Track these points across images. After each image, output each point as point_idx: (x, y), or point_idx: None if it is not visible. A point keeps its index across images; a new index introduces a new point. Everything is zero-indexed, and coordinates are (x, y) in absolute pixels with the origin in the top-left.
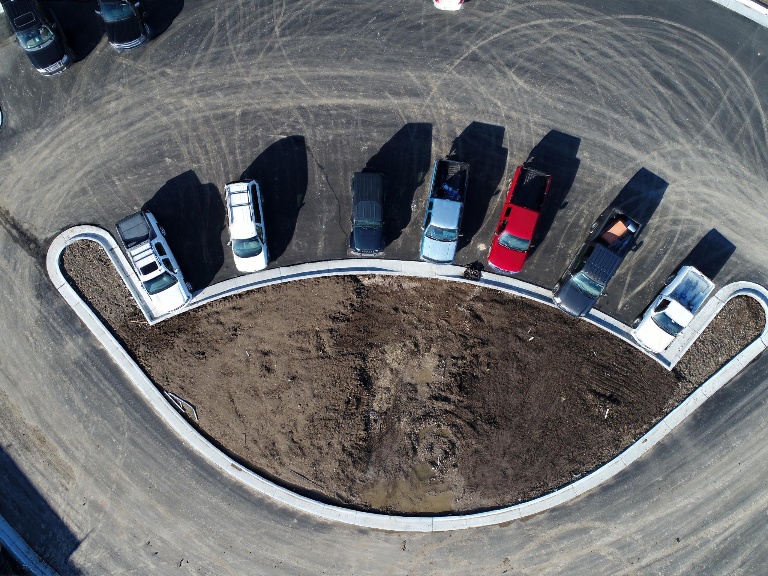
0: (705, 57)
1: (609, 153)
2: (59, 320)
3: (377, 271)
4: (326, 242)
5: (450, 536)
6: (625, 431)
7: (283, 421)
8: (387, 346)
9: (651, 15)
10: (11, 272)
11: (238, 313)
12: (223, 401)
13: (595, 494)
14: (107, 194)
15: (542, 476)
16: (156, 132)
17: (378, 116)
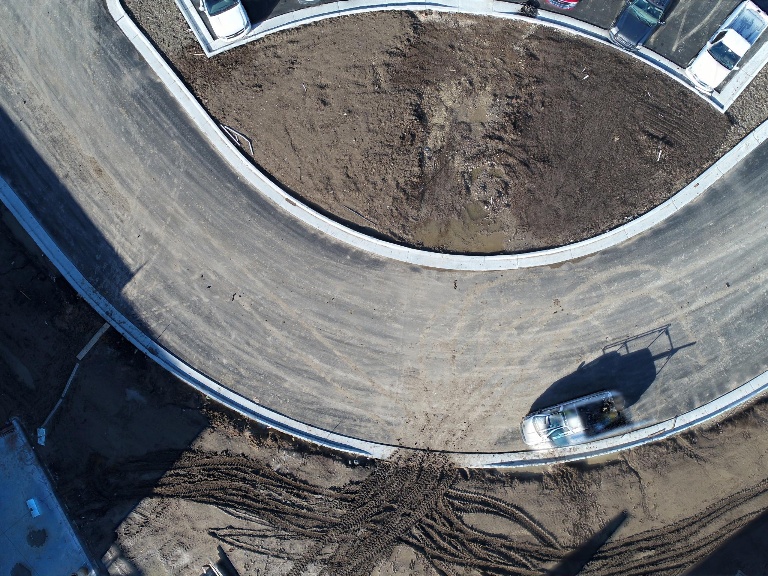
0: None
1: None
2: (117, 53)
3: (434, 6)
4: None
5: (501, 276)
6: (677, 174)
7: (338, 155)
8: (442, 83)
9: None
10: (70, 4)
11: (295, 46)
12: (279, 134)
13: (646, 237)
14: None
15: (594, 217)
16: None
17: None
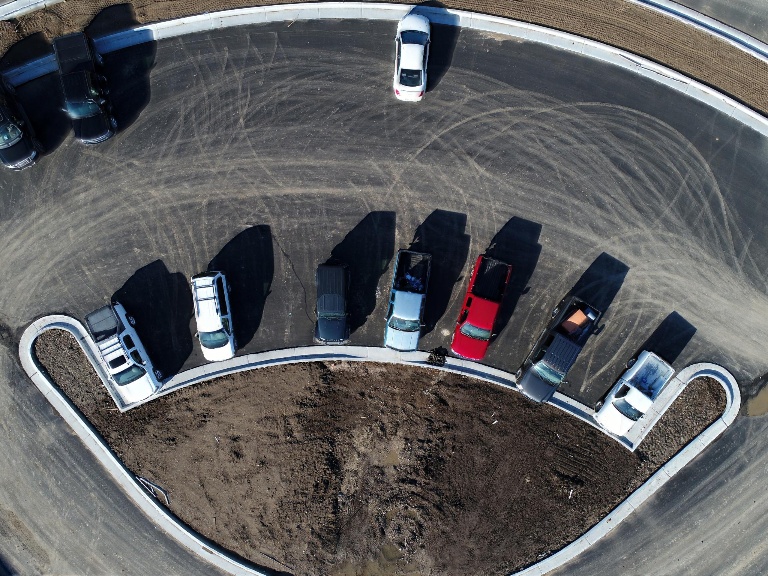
0: (664, 143)
1: (570, 238)
2: (32, 408)
3: (343, 358)
4: (292, 329)
5: None
6: (589, 511)
7: (252, 505)
8: (354, 430)
9: (610, 102)
10: None
11: (207, 400)
12: (193, 486)
13: (560, 573)
14: (77, 284)
15: (508, 556)
16: (125, 223)
17: (342, 205)
